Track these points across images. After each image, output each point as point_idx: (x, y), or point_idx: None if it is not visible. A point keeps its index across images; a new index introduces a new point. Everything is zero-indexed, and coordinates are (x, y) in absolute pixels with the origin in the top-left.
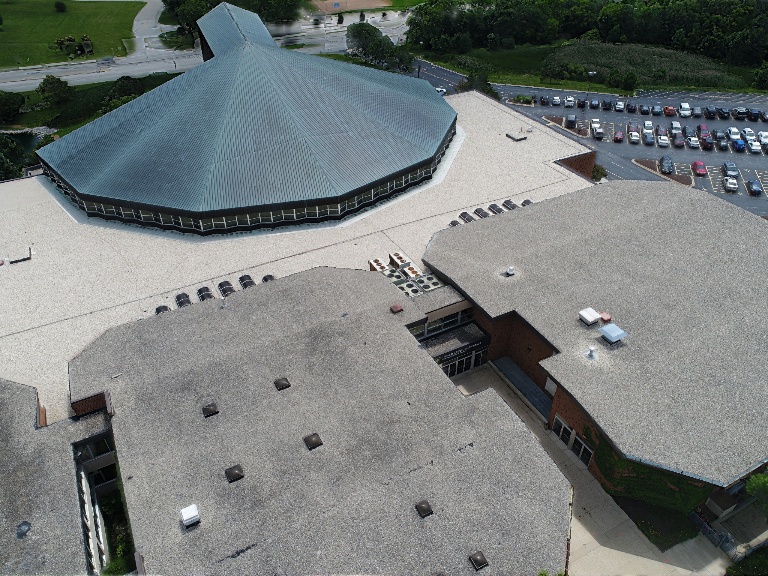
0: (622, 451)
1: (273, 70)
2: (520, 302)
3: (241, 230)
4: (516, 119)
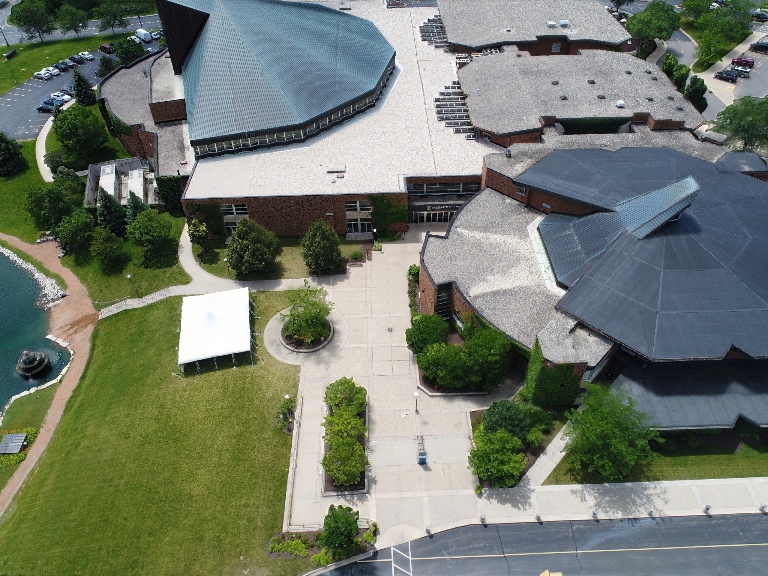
0: (615, 42)
1: (259, 6)
2: (531, 33)
3: (379, 95)
4: (321, 2)
